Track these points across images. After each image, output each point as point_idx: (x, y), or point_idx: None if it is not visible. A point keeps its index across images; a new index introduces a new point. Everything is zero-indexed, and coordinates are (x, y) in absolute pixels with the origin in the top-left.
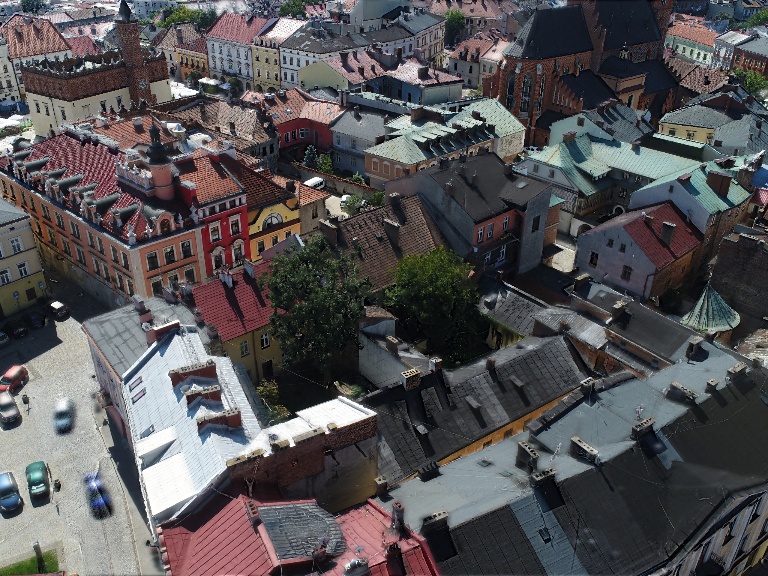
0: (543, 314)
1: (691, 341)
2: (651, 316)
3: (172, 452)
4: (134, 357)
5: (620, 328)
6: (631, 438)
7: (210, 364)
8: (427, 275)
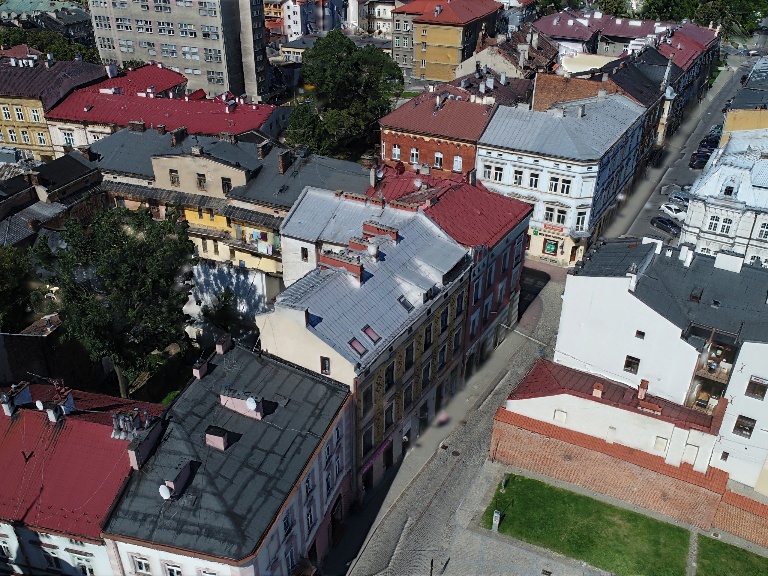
0: (6, 238)
1: (88, 147)
2: (41, 167)
3: (417, 267)
4: (295, 421)
5: (54, 184)
6: (236, 143)
7: (330, 251)
8: (4, 255)
